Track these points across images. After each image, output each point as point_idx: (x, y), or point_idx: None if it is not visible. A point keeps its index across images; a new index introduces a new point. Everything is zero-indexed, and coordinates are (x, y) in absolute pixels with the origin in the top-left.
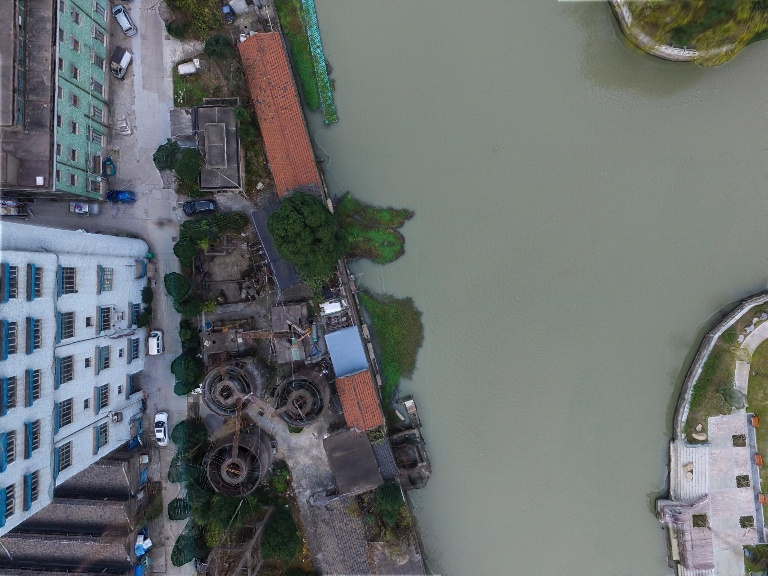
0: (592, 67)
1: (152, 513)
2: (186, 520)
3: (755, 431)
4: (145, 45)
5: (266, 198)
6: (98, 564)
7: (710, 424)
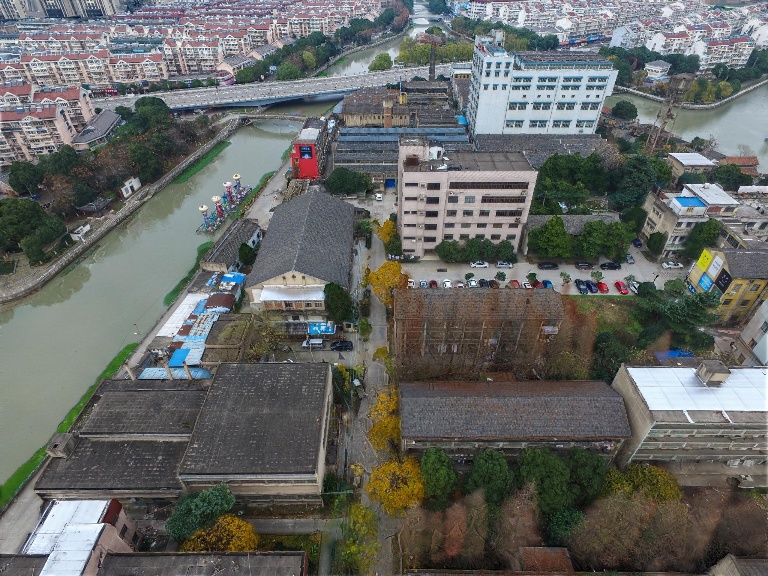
0: None
1: None
2: None
3: None
4: None
5: (599, 120)
6: None
7: None
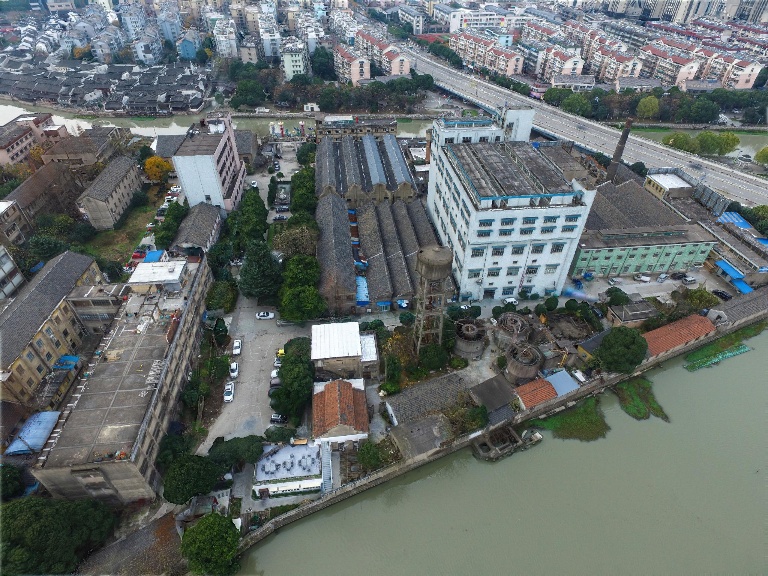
0: None
1: (414, 310)
2: None
3: None
4: (657, 286)
5: None
6: None
7: None
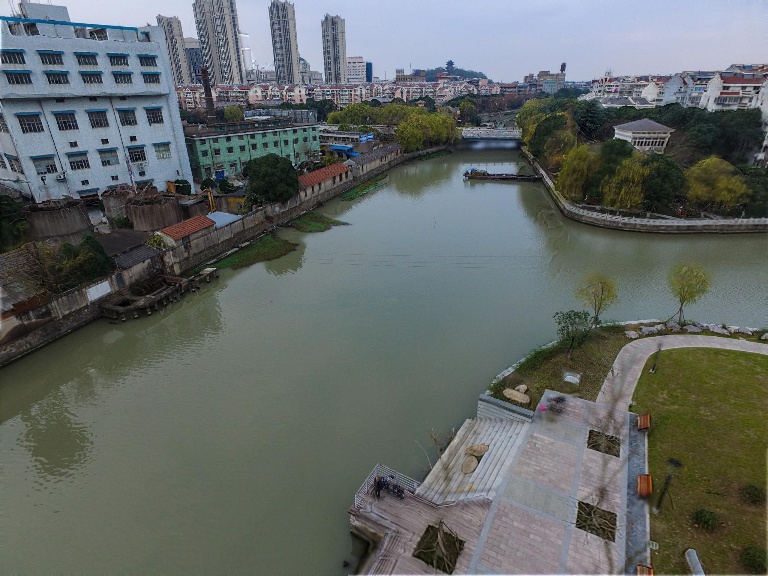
0: (555, 262)
1: None
2: None
3: (647, 444)
4: None
5: None
6: None
7: (546, 397)
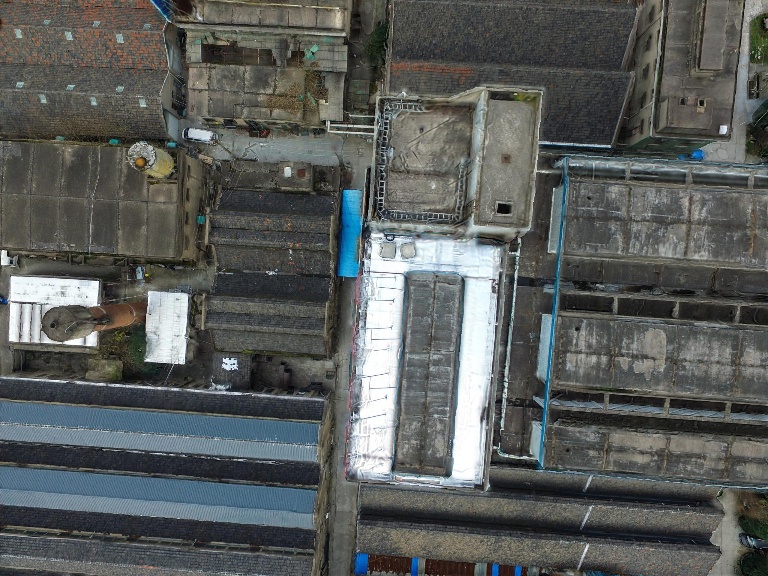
0: None
1: None
2: (731, 494)
3: None
4: None
5: None
6: (678, 536)
7: None
